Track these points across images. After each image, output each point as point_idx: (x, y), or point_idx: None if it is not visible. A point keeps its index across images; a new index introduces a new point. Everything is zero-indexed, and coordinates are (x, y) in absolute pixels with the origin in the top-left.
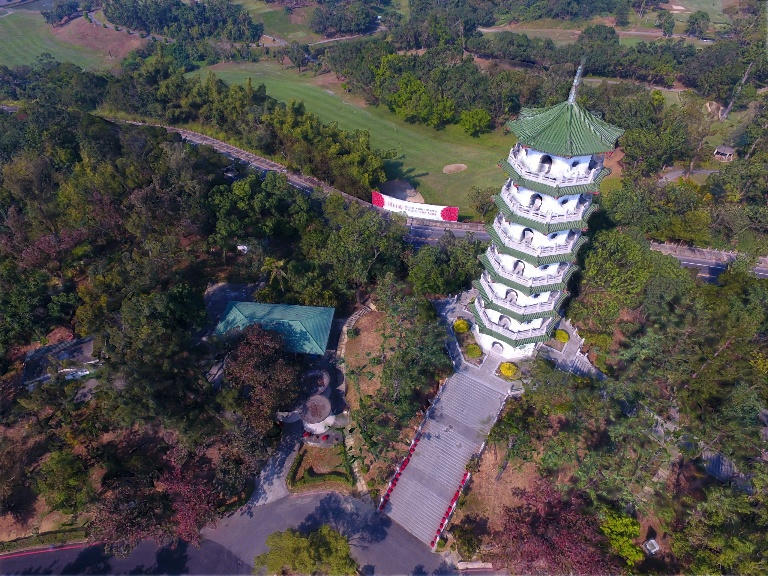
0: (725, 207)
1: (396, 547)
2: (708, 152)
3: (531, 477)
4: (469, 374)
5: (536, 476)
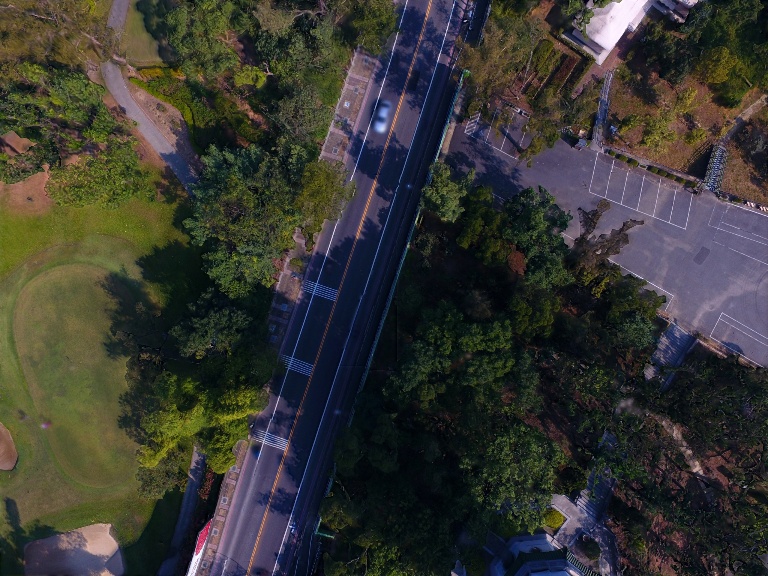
0: (283, 111)
1: None
2: (111, 33)
3: (671, 568)
4: None
5: (671, 563)
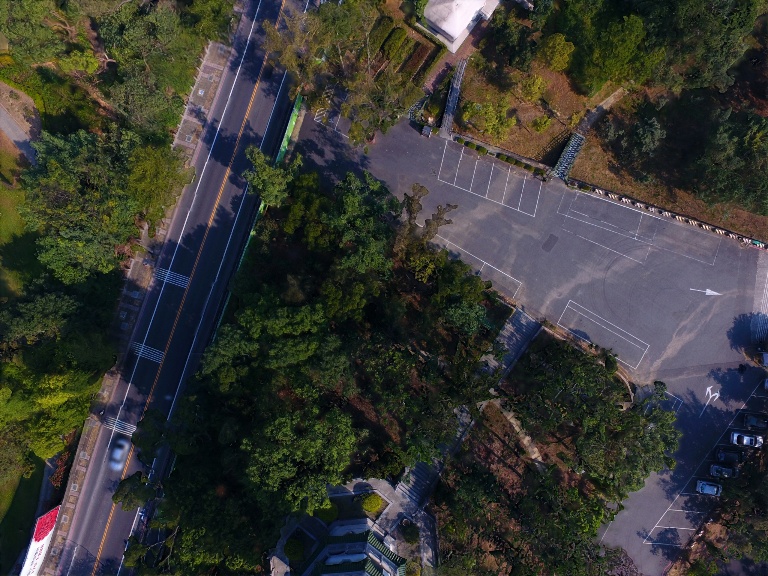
0: (115, 97)
1: None
2: None
3: None
4: None
5: None
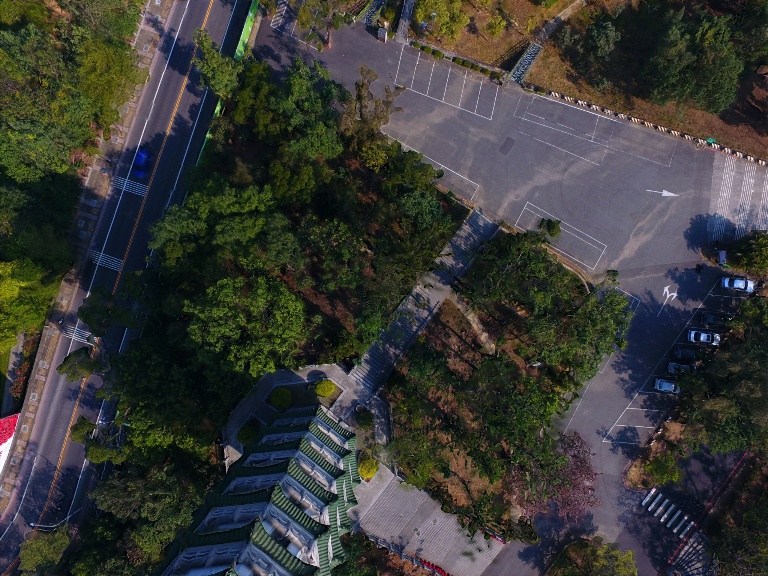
0: None
1: (503, 574)
2: None
3: None
4: (364, 511)
5: None
